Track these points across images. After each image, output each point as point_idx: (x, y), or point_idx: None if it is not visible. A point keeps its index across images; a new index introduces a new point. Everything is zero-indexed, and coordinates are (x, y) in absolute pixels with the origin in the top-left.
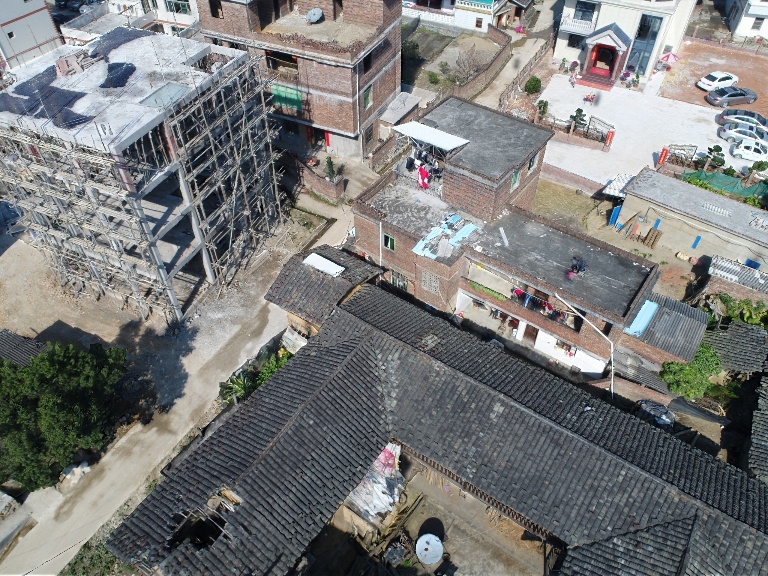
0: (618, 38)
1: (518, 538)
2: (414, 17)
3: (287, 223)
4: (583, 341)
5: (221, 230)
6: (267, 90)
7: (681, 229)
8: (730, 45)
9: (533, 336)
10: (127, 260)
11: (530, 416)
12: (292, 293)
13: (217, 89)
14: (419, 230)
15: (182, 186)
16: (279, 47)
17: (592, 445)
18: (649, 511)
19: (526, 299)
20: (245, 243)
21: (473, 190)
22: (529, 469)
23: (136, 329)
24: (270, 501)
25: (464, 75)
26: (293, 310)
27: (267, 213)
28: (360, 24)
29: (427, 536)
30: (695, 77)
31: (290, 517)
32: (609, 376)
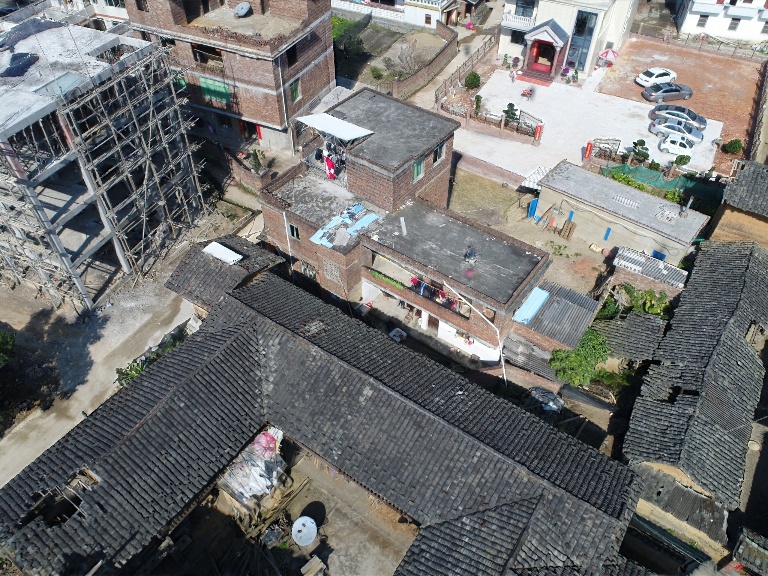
0: (555, 34)
1: (395, 521)
2: (366, 13)
3: (212, 215)
4: (474, 329)
5: (133, 220)
6: (196, 83)
7: (593, 221)
8: (674, 42)
9: (436, 325)
10: (29, 248)
11: (396, 399)
12: (191, 281)
13: (117, 79)
14: (321, 219)
15: (84, 175)
16: (203, 40)
17: (451, 427)
18: (499, 491)
19: (421, 287)
20: (165, 234)
21: (373, 180)
22: (391, 451)
23: (47, 317)
24: (130, 481)
25: (408, 70)
26: (190, 297)
27: (191, 204)
28: (287, 18)
29: (303, 518)
30: (635, 73)
31: (149, 496)
32: (501, 363)
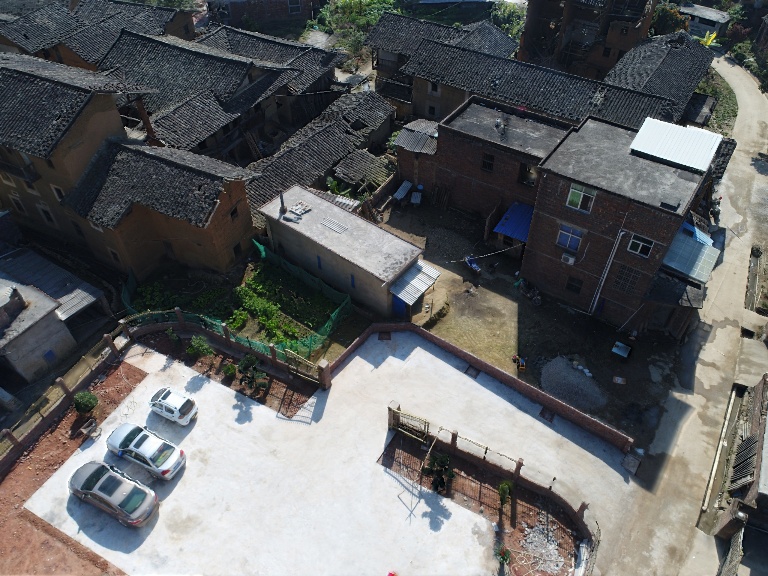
0: None
1: None
2: None
3: None
4: None
5: None
6: None
7: None
8: None
9: None
10: None
11: None
12: None
13: None
14: None
15: None
16: None
17: None
18: None
19: None
20: None
21: None
22: None
23: None
24: None
25: None
26: None
27: None
28: None
29: None
30: None
31: None
32: None
